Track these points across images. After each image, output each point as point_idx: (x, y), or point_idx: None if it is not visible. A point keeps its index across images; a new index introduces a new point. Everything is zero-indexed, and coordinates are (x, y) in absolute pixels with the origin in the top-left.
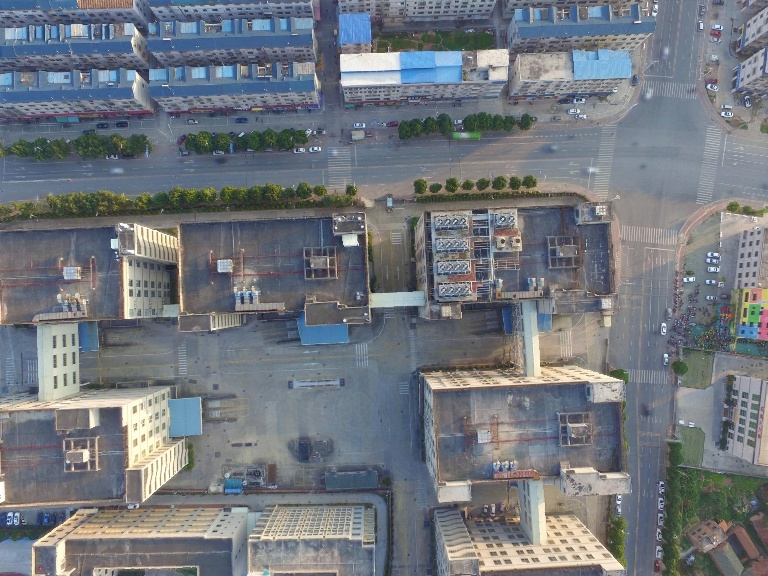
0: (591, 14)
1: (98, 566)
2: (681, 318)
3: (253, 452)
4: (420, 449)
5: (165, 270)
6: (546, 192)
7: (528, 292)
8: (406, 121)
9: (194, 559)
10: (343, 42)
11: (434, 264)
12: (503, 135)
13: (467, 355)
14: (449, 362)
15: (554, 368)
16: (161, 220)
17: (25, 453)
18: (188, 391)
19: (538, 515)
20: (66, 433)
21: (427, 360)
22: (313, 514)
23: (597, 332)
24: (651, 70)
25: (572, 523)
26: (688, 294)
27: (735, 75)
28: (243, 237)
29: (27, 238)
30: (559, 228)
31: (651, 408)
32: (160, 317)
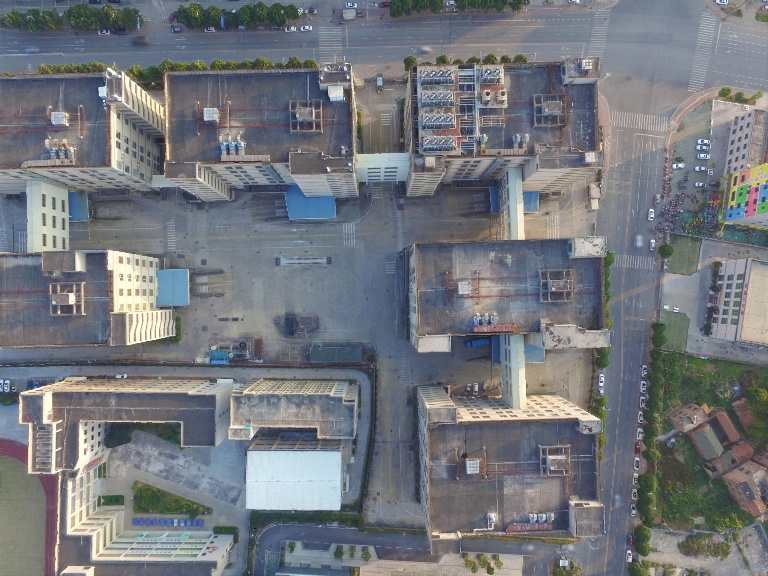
0: None
1: (84, 419)
2: (669, 204)
3: (240, 327)
4: (405, 328)
5: (155, 143)
6: None
7: (513, 149)
8: None
9: (178, 415)
10: None
11: (419, 118)
12: (495, 18)
13: (454, 236)
14: None
15: None
16: (152, 96)
17: (12, 297)
18: (176, 265)
19: (518, 379)
20: (52, 274)
21: (414, 240)
22: (297, 383)
23: (584, 217)
24: None
25: (553, 398)
26: (677, 181)
27: None
28: (230, 90)
29: (16, 86)
30: (545, 87)
31: (636, 293)
32: (150, 191)
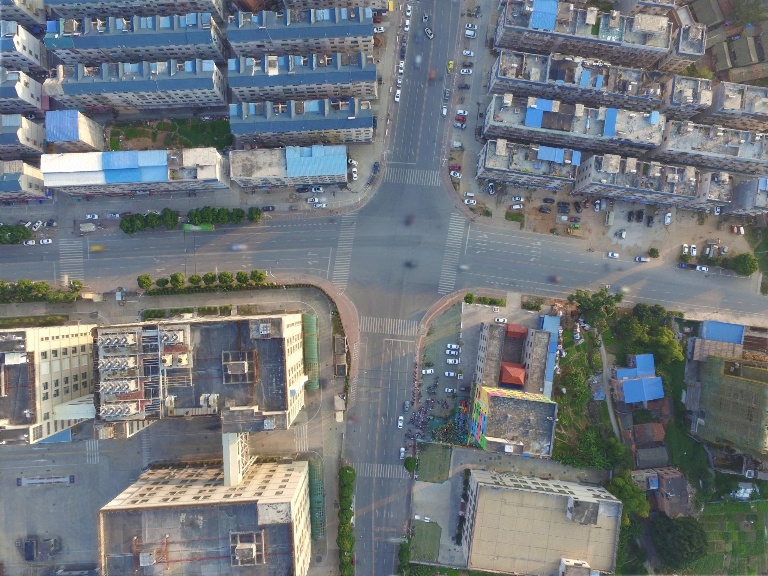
0: (308, 108)
1: None
2: (419, 411)
3: None
4: None
5: None
6: (281, 284)
7: (201, 409)
8: (128, 216)
9: None
10: (50, 140)
11: None
12: (239, 225)
13: (200, 450)
14: (181, 458)
15: (278, 467)
16: None
17: None
18: None
19: None
20: None
21: (159, 456)
22: None
23: (333, 426)
24: (394, 156)
25: None
26: (427, 386)
27: (477, 162)
28: None
29: None
30: (236, 342)
31: (387, 503)
32: None
